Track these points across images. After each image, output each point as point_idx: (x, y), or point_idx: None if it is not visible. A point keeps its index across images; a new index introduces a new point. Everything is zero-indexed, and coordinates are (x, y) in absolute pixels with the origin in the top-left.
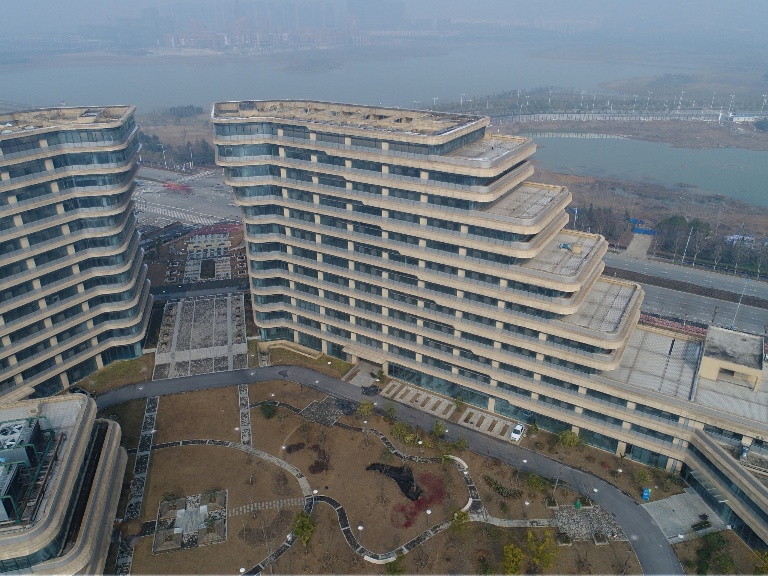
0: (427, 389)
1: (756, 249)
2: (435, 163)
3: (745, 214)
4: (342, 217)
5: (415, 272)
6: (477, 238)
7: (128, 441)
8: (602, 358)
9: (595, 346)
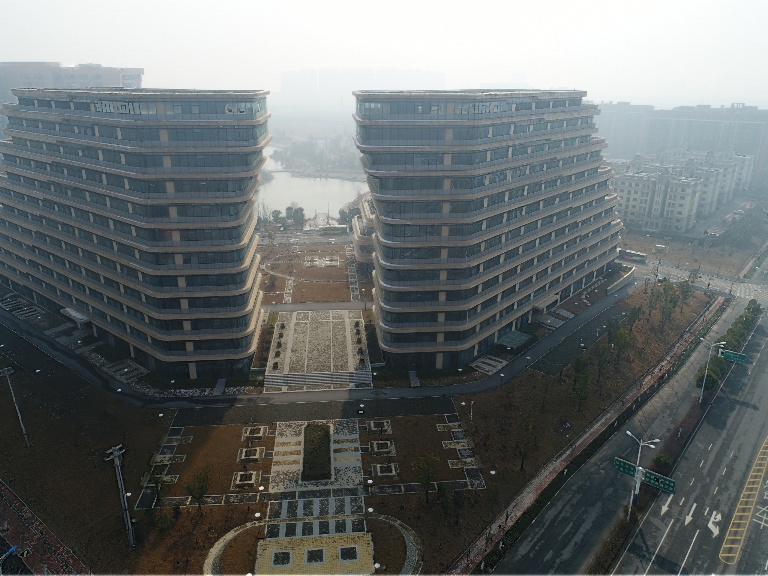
0: None
1: None
2: None
3: None
4: None
5: None
6: None
7: (365, 283)
8: None
9: None
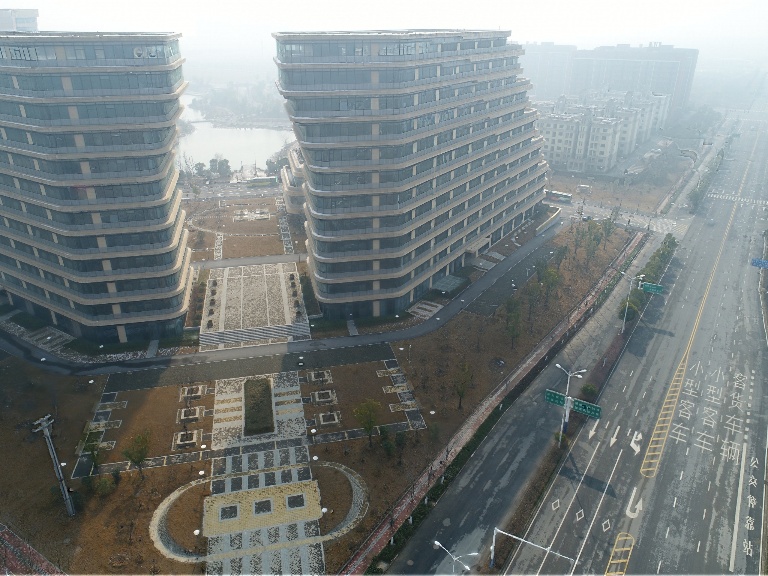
0: None
1: None
2: None
3: None
4: None
5: None
6: None
7: (297, 235)
8: None
9: None
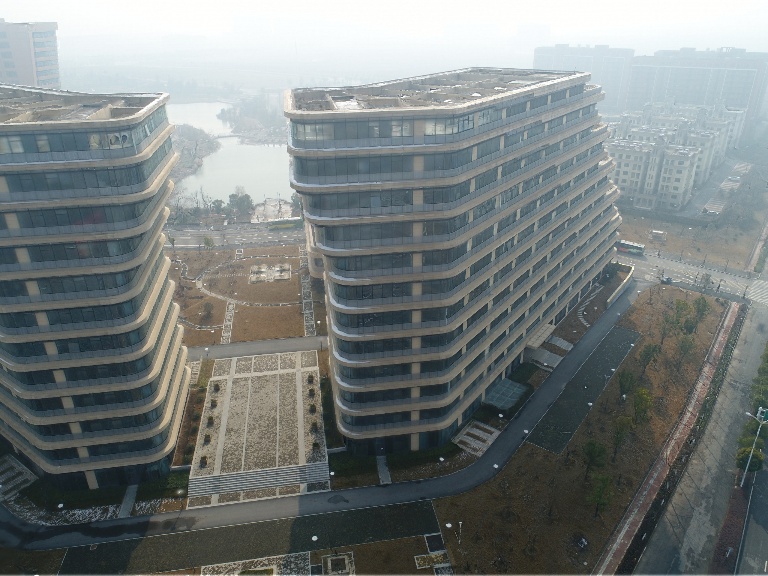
0: None
1: None
2: None
3: None
4: None
5: None
6: None
7: (321, 306)
8: None
9: None
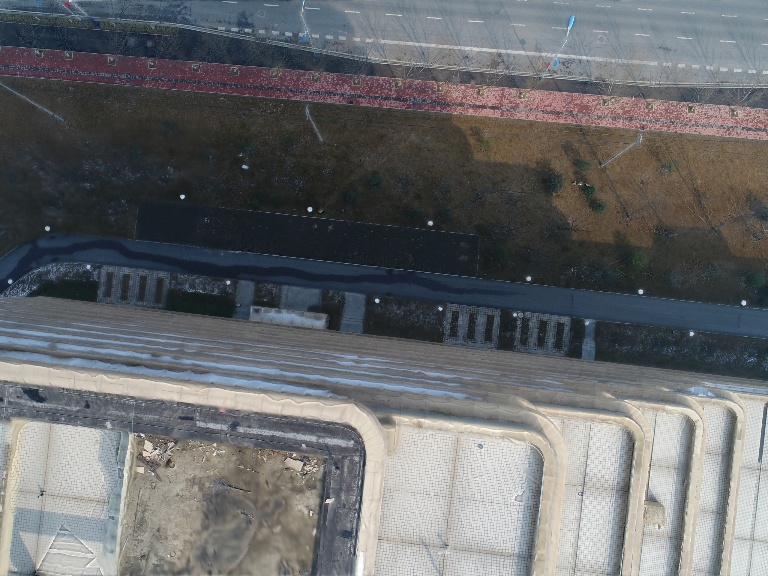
0: None
1: None
2: None
3: None
4: None
5: None
6: None
7: None
8: None
9: None
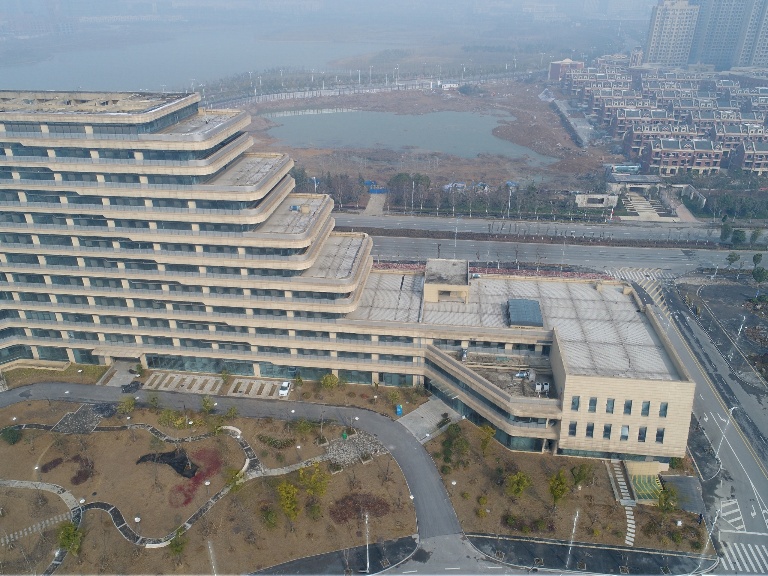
0: (192, 372)
1: (467, 193)
2: (146, 142)
3: (458, 166)
4: (57, 212)
5: (152, 256)
6: (206, 211)
7: None
8: (342, 302)
9: (334, 293)
